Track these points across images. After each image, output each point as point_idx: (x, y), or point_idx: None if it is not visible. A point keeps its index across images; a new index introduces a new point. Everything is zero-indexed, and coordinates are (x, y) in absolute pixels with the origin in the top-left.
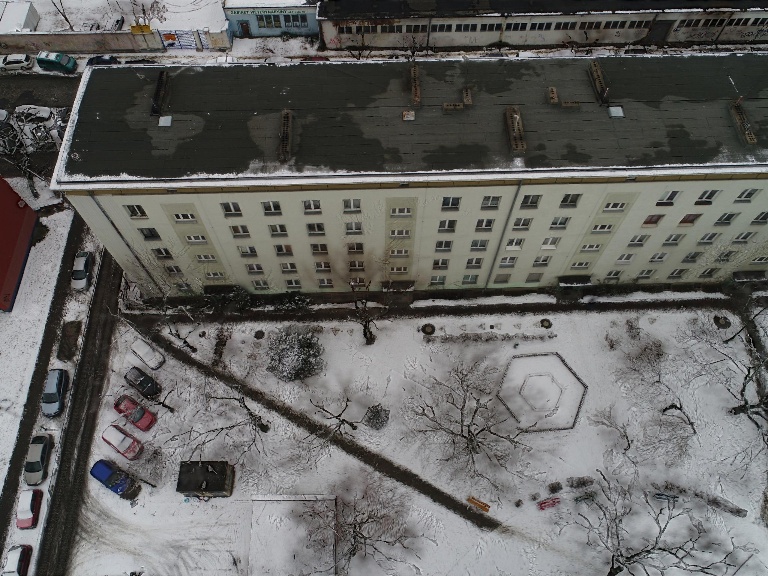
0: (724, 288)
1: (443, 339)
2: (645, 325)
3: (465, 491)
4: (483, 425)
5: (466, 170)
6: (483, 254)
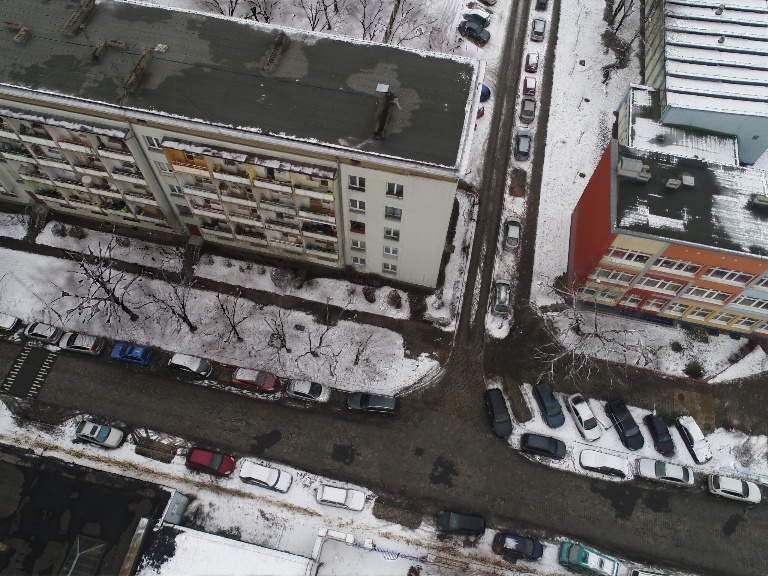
0: None
1: None
2: None
3: None
4: None
5: (142, 5)
6: None
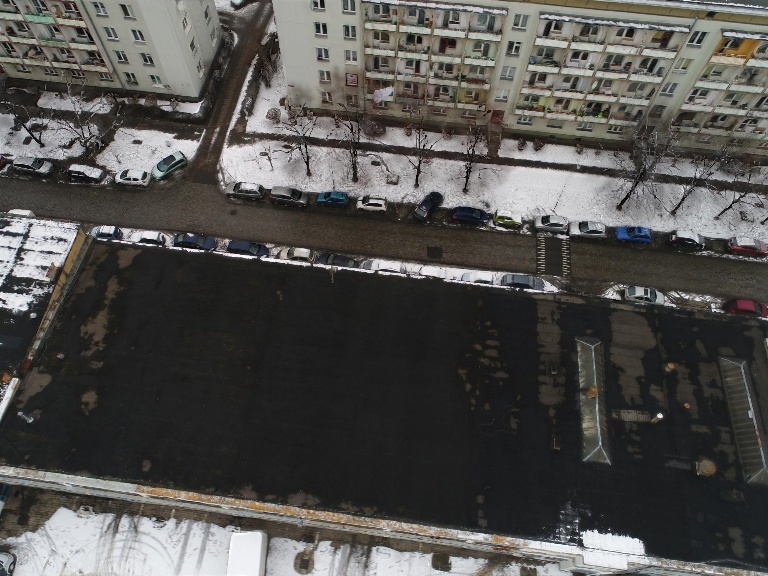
0: None
1: None
2: None
3: None
4: None
5: None
6: None
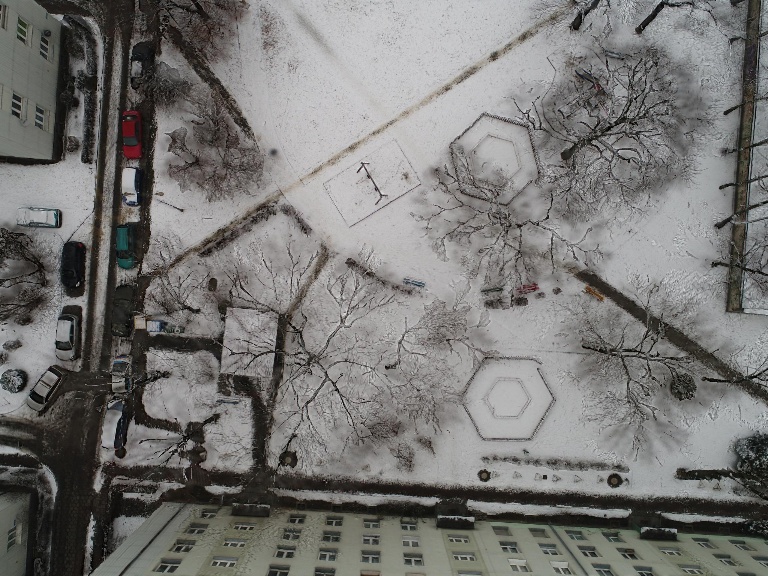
0: (271, 501)
1: (608, 466)
2: (376, 464)
3: (603, 308)
4: (574, 370)
5: None
6: (591, 561)
